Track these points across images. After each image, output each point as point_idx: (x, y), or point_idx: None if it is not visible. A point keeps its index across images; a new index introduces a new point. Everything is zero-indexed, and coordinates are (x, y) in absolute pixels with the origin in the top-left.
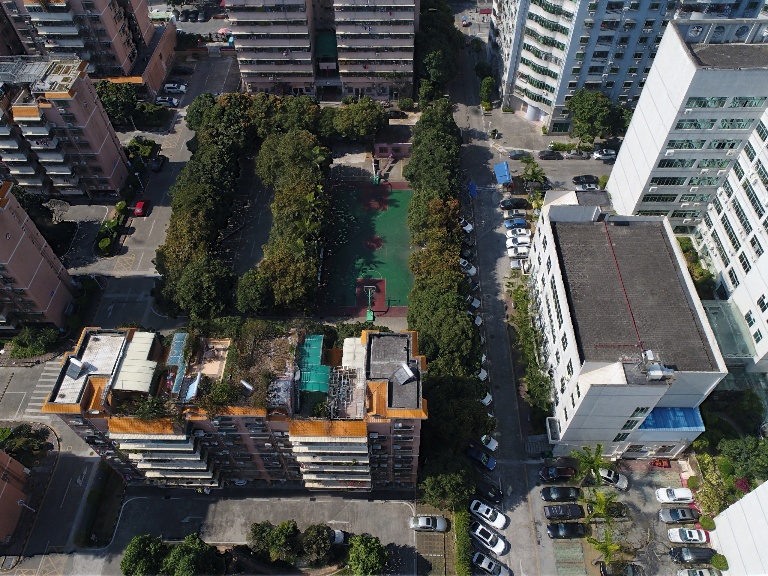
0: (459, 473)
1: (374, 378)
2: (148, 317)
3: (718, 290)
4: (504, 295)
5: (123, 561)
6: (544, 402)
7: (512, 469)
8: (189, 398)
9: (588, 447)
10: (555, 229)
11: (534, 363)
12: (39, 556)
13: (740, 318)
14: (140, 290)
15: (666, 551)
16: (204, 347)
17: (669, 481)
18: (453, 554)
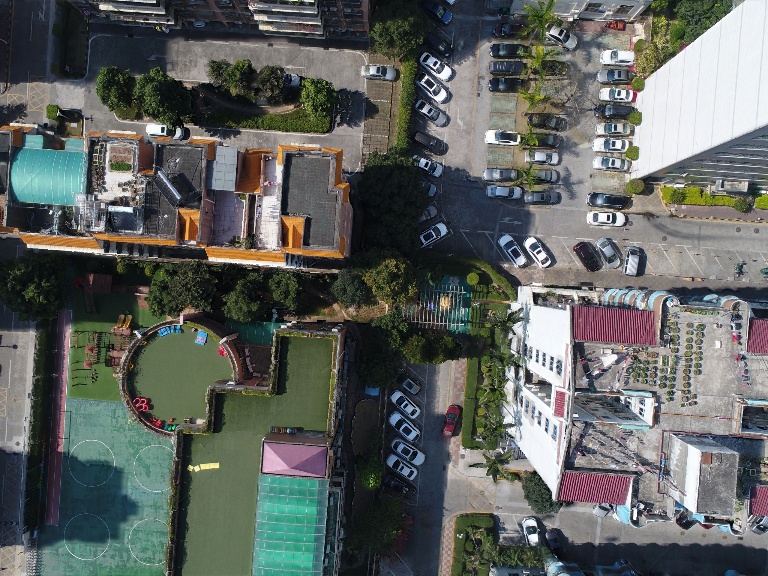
0: (407, 21)
1: None
2: None
3: None
4: None
5: (97, 88)
6: None
7: (467, 24)
8: None
9: (546, 3)
10: None
11: None
12: (24, 84)
13: None
14: None
15: (592, 107)
16: None
17: (618, 44)
18: (399, 101)
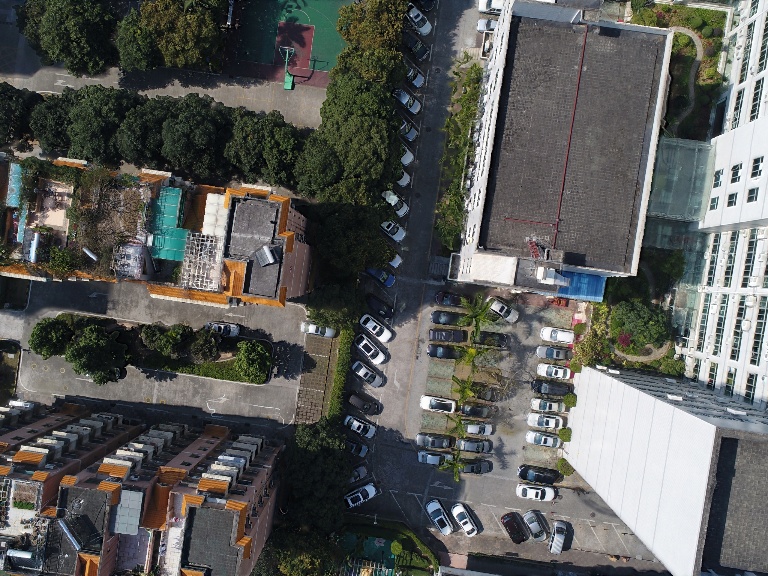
0: (341, 311)
1: (233, 254)
2: (24, 48)
3: (720, 104)
4: (457, 71)
5: None
6: (450, 241)
7: (411, 287)
8: (28, 263)
9: (487, 285)
10: (517, 30)
11: (453, 193)
12: None
13: (711, 170)
14: (8, 4)
15: (530, 380)
16: (45, 189)
17: (560, 319)
18: (337, 357)
